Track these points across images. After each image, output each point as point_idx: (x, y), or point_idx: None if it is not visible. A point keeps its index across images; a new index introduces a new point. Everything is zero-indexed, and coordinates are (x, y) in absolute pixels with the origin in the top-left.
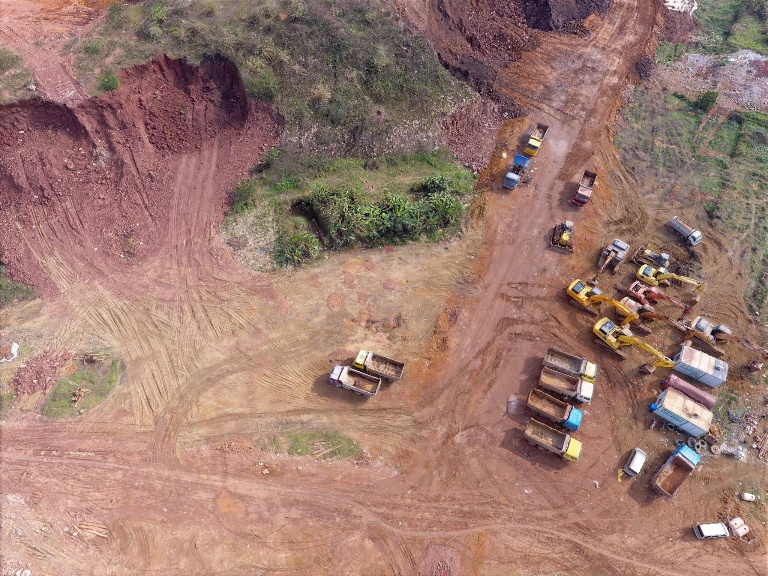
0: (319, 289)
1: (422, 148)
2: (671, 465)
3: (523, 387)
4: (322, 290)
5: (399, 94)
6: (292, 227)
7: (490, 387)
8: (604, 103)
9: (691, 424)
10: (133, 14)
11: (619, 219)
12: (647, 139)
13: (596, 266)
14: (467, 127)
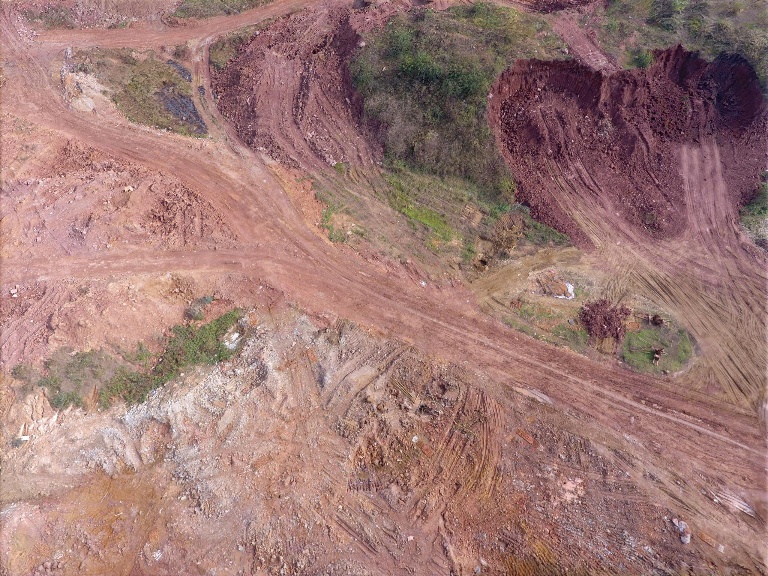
0: None
1: None
2: None
3: None
4: None
5: None
6: None
7: None
8: None
9: None
10: (634, 3)
11: None
12: None
13: None
14: None
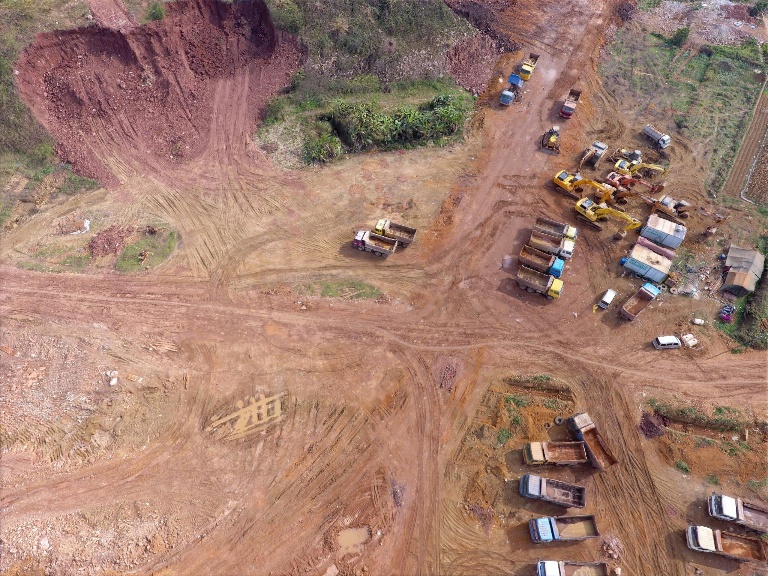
0: (342, 181)
1: (428, 75)
2: (636, 298)
3: (516, 249)
4: (345, 182)
5: (408, 27)
6: (317, 136)
7: (488, 250)
8: (589, 40)
9: (654, 269)
10: None
11: (600, 129)
12: (627, 69)
13: (579, 164)
14: (468, 59)
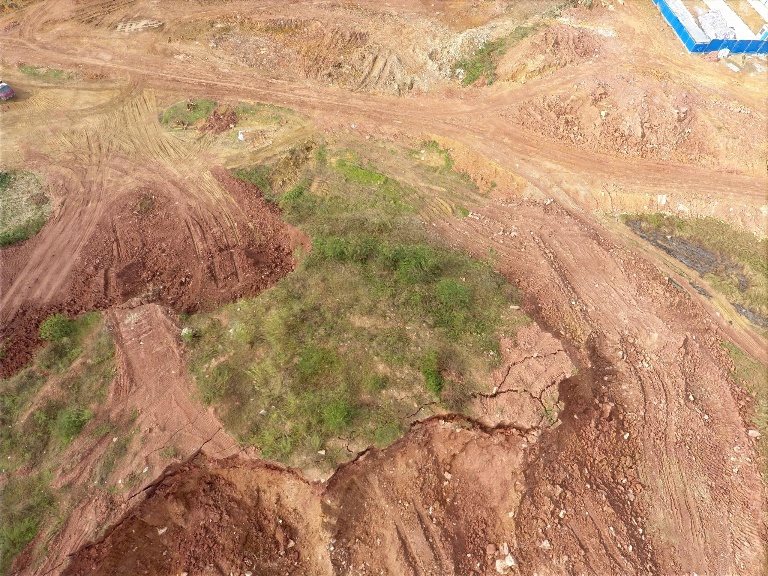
0: None
1: None
2: None
3: None
4: None
5: None
6: None
7: None
8: None
9: None
10: None
11: None
12: None
13: None
14: None
